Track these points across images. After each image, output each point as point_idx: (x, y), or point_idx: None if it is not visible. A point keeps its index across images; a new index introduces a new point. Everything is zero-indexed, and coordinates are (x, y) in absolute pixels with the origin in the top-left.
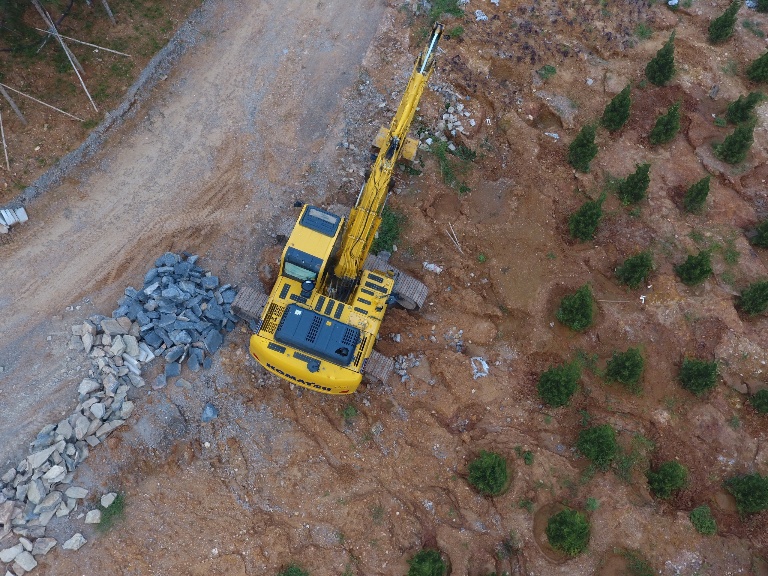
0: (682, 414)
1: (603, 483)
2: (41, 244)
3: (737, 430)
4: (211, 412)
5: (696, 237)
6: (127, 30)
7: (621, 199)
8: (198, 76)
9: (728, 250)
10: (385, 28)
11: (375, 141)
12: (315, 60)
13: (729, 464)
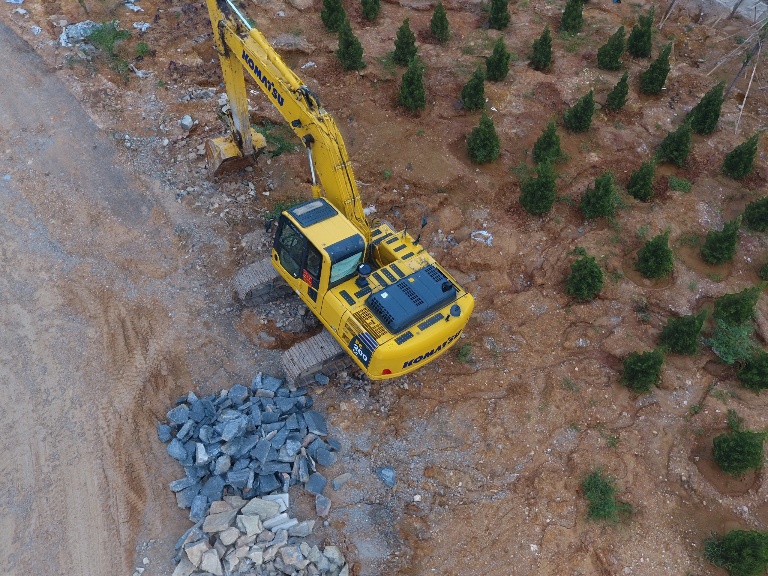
0: (597, 147)
1: (626, 220)
2: (3, 573)
3: (625, 128)
4: (389, 472)
5: (469, 51)
6: None
7: (404, 66)
8: None
9: (493, 43)
10: (79, 88)
11: (223, 154)
12: (50, 160)
13: (645, 149)
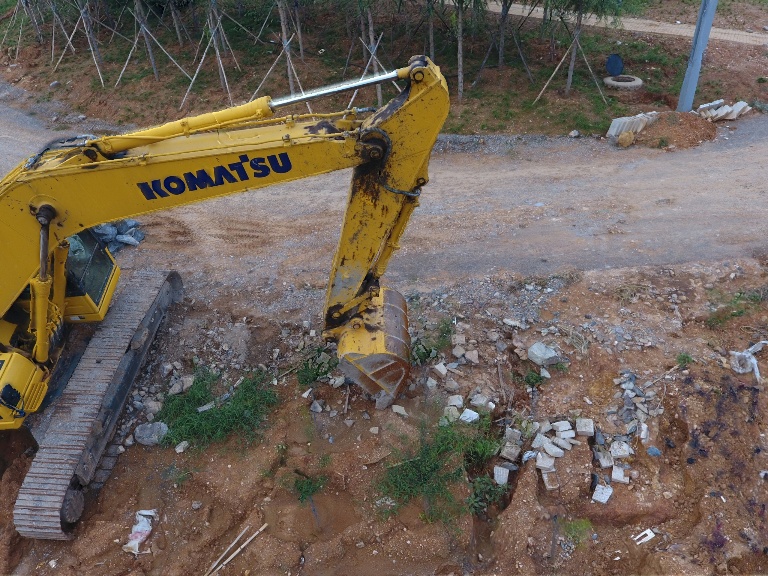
0: None
1: None
2: None
3: None
4: None
5: None
6: (457, 108)
7: None
8: (439, 168)
9: None
10: (698, 269)
11: None
12: (547, 230)
13: None
